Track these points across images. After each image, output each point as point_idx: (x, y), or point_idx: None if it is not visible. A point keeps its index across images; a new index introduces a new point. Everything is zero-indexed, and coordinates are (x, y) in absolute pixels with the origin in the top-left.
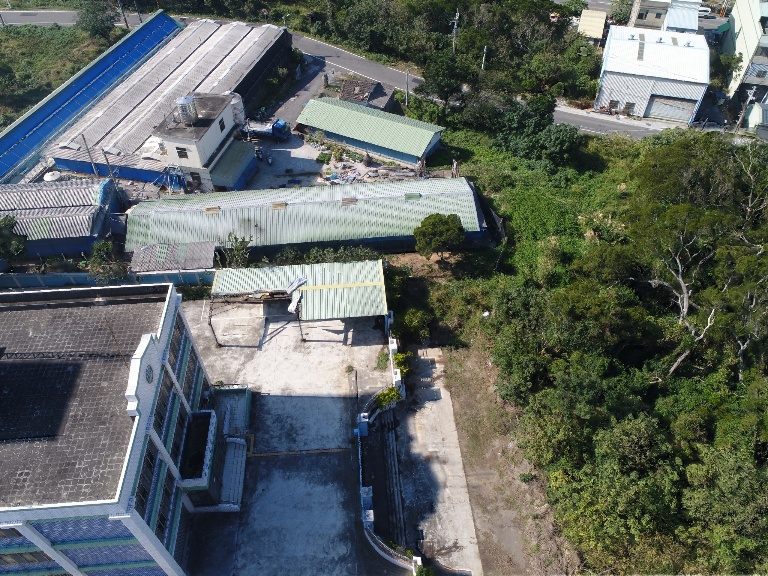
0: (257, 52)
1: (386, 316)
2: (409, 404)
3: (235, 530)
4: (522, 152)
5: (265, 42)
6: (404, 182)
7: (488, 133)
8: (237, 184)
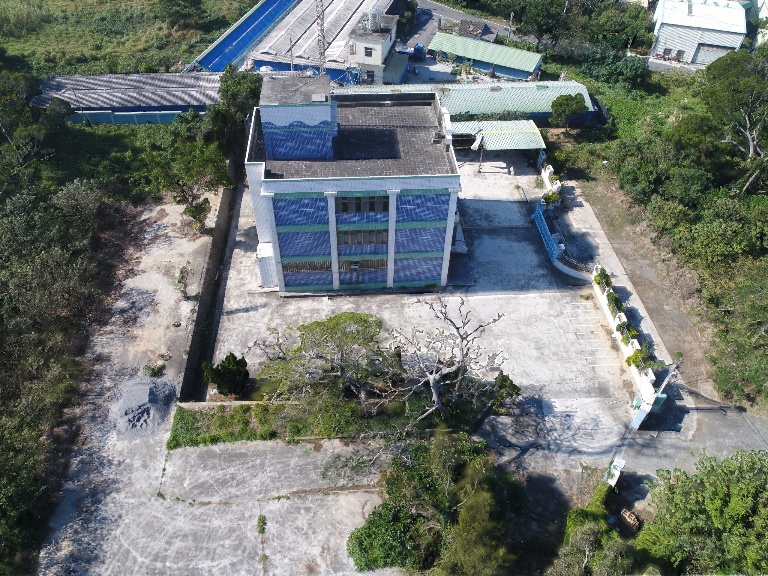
0: None
1: None
2: (562, 208)
3: (467, 261)
4: (603, 78)
5: None
6: (529, 82)
7: None
8: (399, 83)
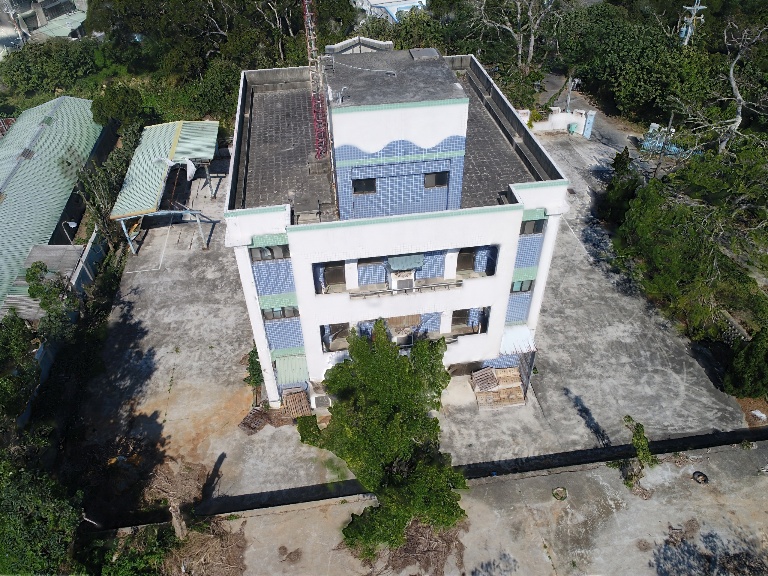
0: None
1: None
2: None
3: None
4: None
5: None
6: (4, 139)
7: None
8: None
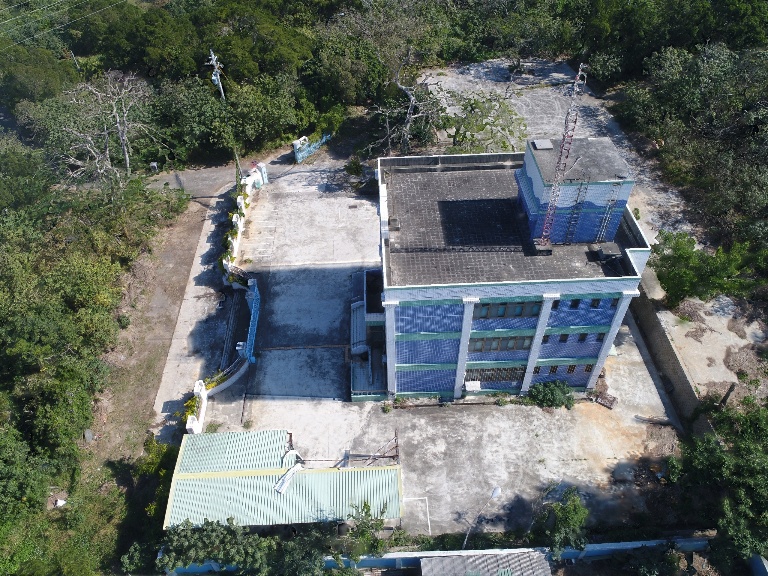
0: None
1: None
2: None
3: None
4: None
5: None
6: None
7: None
8: None
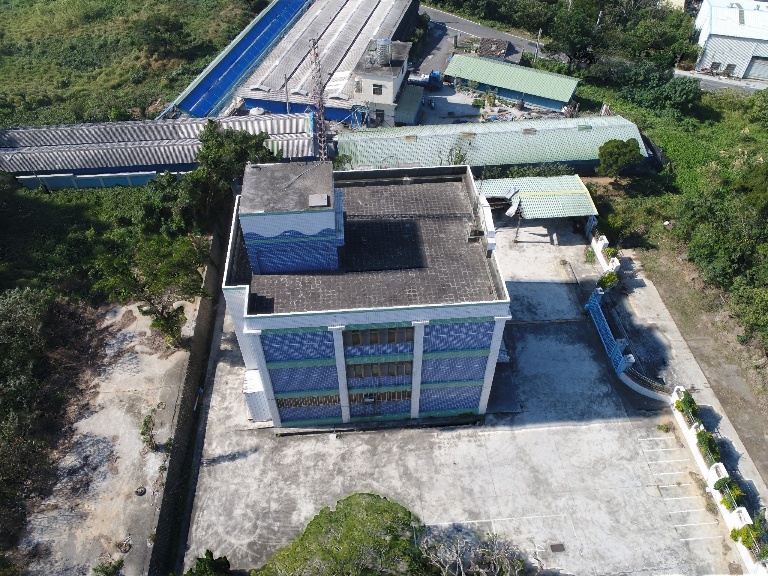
0: (397, 14)
1: (592, 218)
2: (620, 290)
3: (510, 375)
4: (647, 103)
5: (401, 6)
6: (568, 119)
7: (610, 88)
8: (414, 122)
